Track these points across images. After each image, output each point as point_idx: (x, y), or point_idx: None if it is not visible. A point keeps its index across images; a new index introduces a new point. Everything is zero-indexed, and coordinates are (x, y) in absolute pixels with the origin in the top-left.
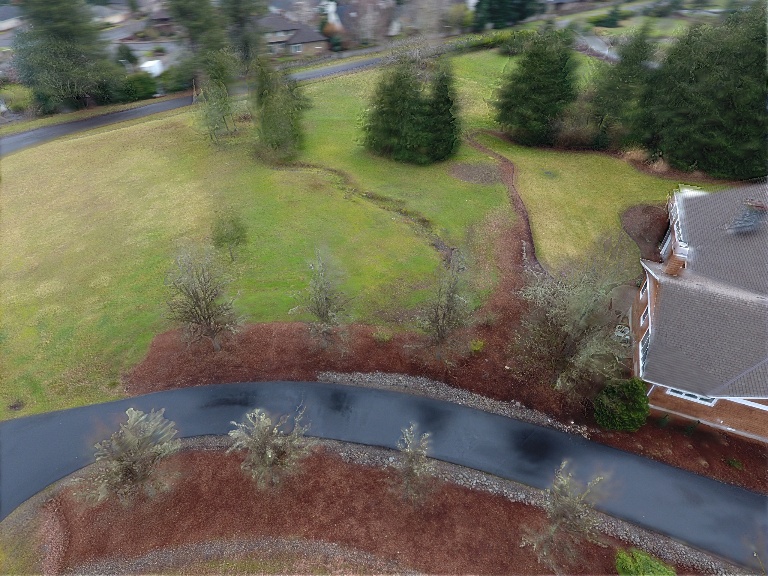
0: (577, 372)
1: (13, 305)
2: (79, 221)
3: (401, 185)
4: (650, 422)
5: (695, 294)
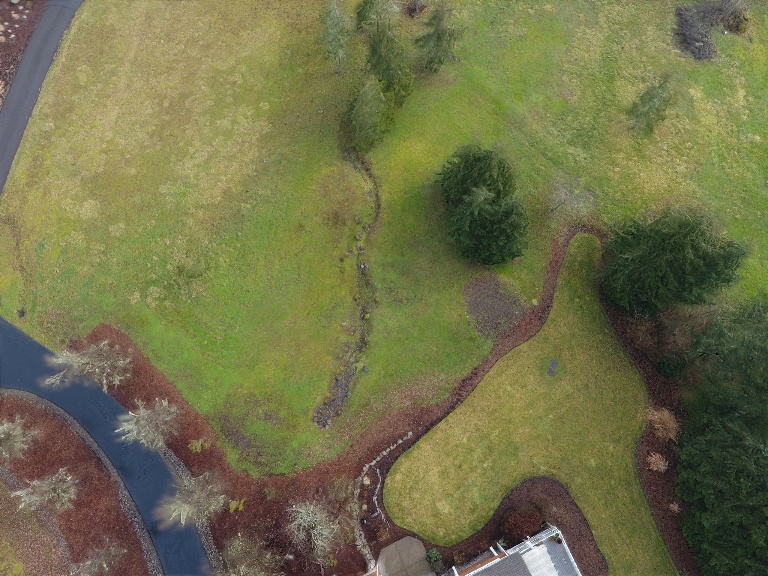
0: None
1: (64, 212)
2: (158, 126)
3: (408, 275)
4: None
5: None
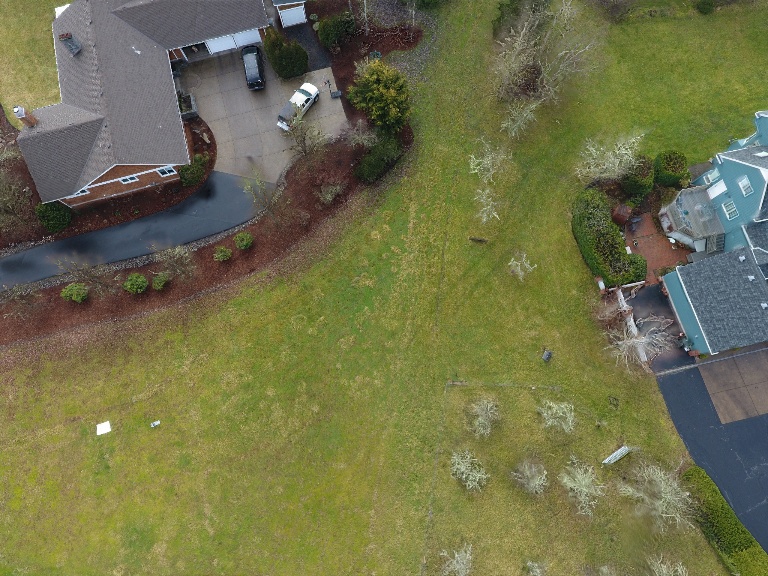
0: (0, 223)
1: None
2: None
3: None
4: (77, 214)
5: (38, 140)
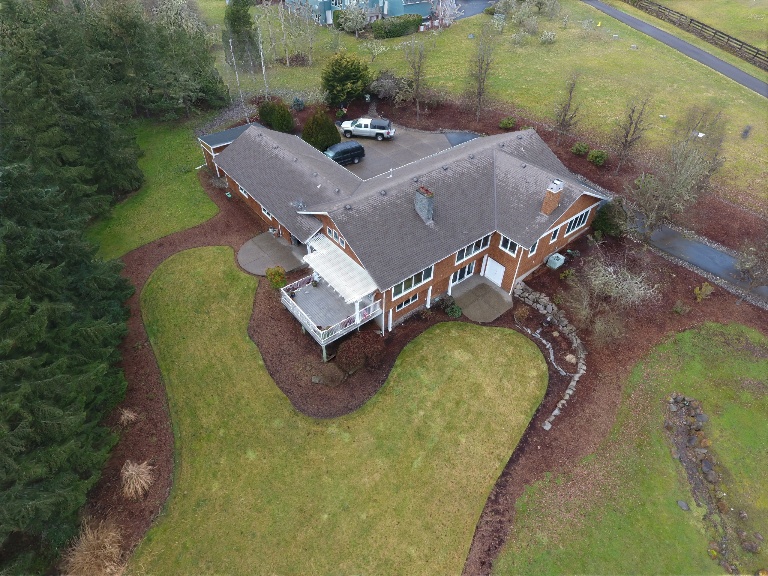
0: None
1: None
2: None
3: None
4: None
5: None
